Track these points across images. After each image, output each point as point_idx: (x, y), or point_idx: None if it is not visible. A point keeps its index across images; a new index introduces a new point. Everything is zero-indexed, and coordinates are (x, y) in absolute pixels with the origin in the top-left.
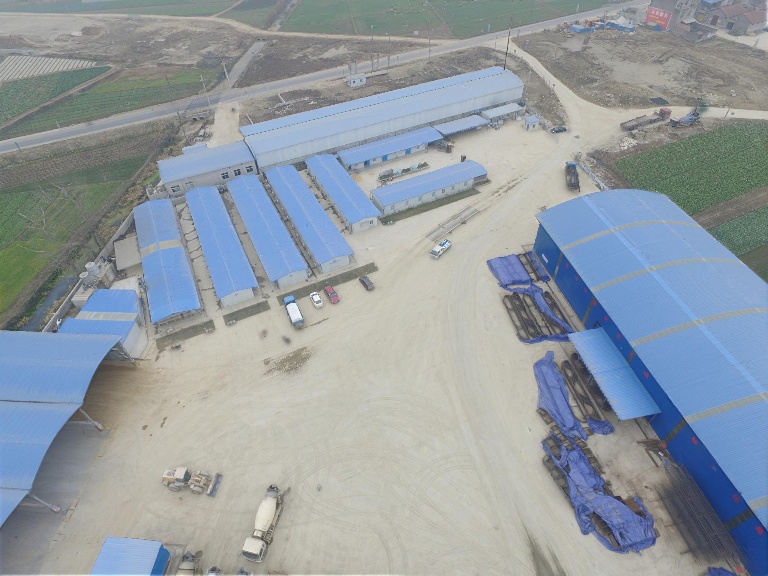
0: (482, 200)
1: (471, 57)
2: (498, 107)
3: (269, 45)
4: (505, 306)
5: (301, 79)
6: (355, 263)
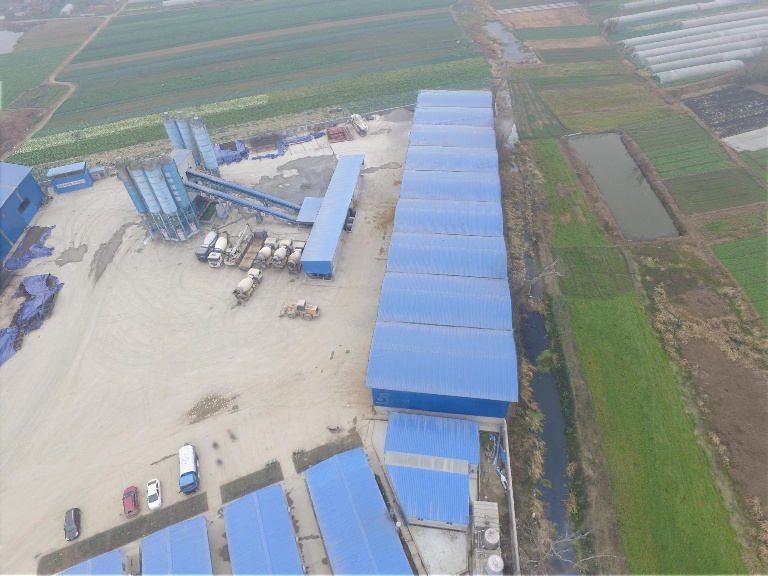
0: None
1: None
2: None
3: None
4: None
5: None
6: None
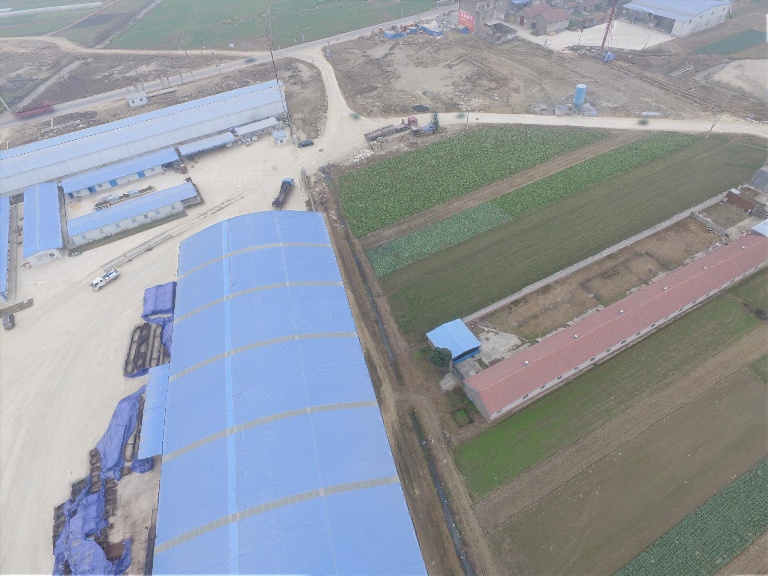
0: (183, 224)
1: (270, 69)
2: (254, 123)
3: (83, 64)
4: (131, 338)
5: (88, 100)
6: (13, 300)
